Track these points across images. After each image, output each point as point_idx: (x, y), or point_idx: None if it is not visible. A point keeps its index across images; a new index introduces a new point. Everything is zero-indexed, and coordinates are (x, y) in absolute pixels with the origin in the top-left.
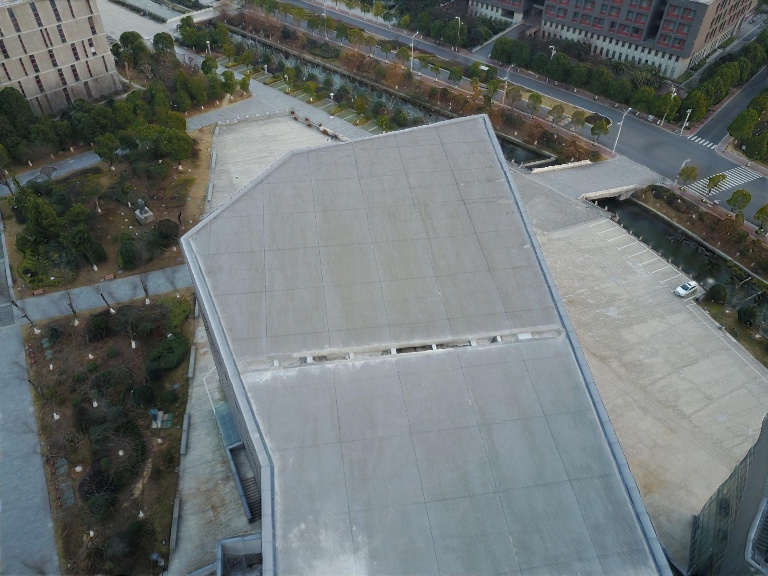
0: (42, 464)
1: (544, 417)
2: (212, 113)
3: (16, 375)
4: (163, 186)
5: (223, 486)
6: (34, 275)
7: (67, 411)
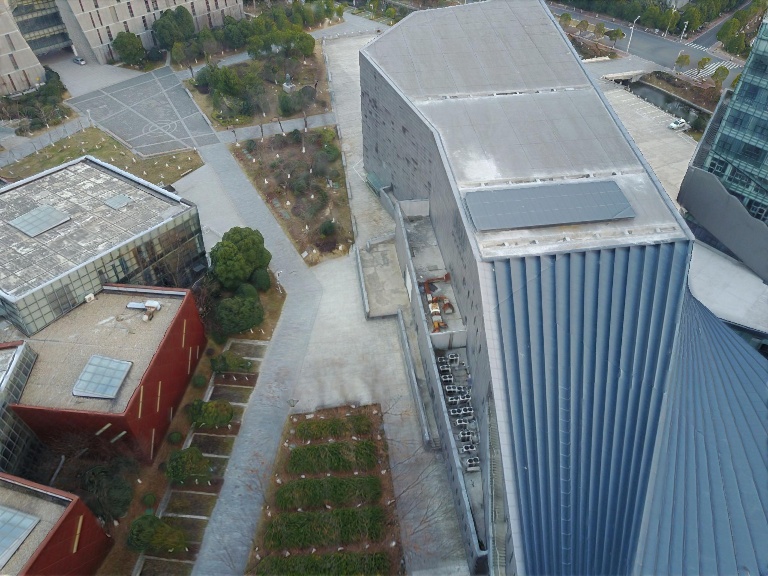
0: (264, 203)
1: (582, 117)
2: (318, 32)
3: (232, 166)
4: (296, 72)
5: (379, 212)
6: (225, 118)
7: (272, 180)
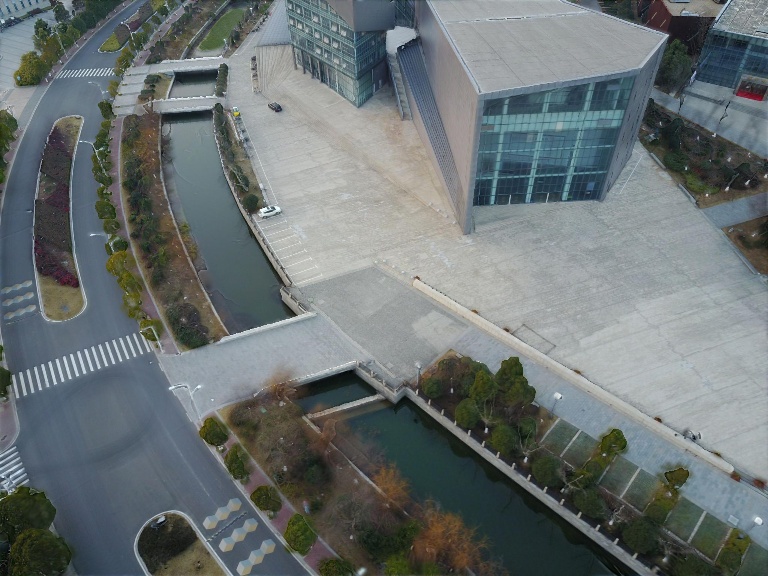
0: None
1: None
2: None
3: None
4: None
5: None
6: None
7: None
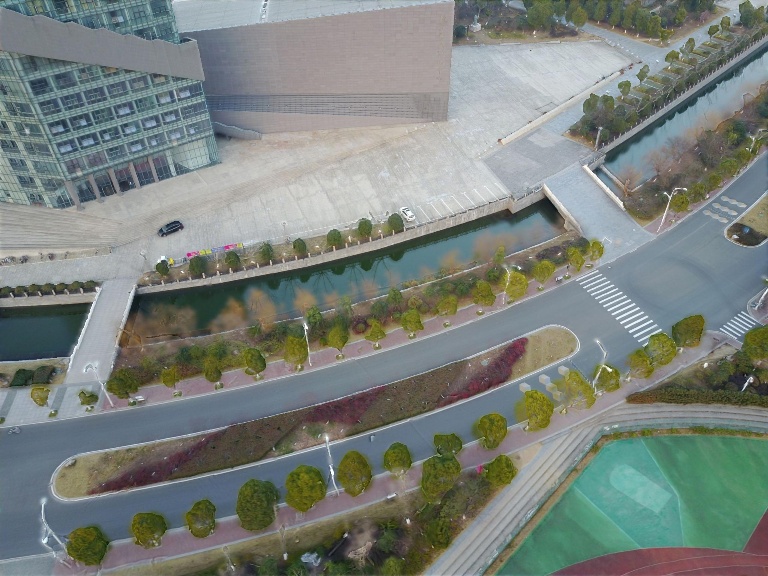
0: None
1: None
2: (622, 37)
3: None
4: (509, 29)
5: None
6: None
7: None
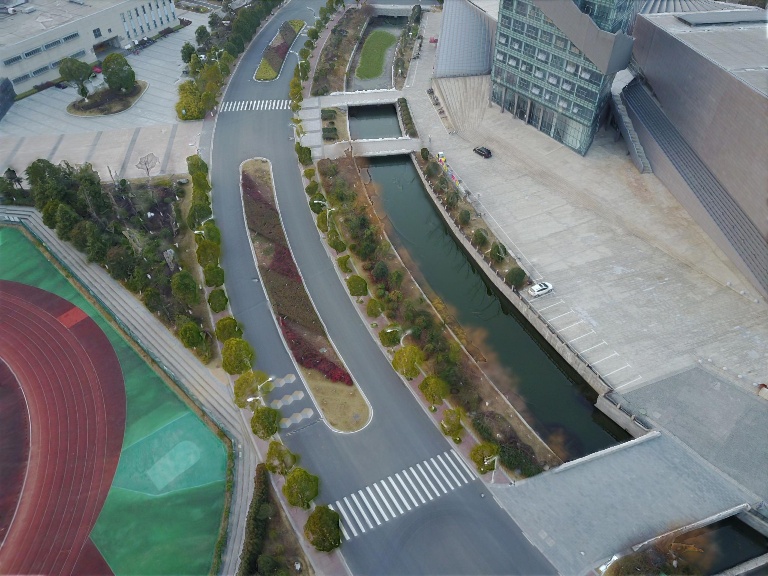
0: None
1: None
2: None
3: None
4: None
5: None
6: None
7: None
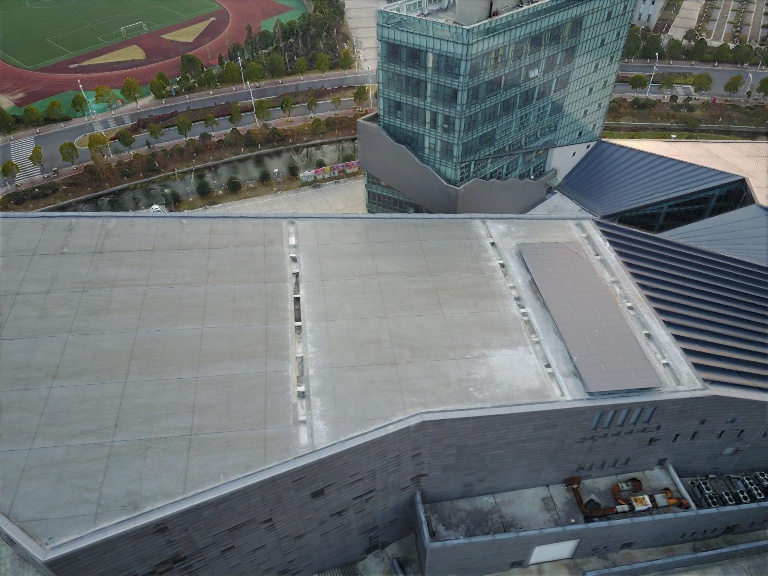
0: None
1: (371, 243)
2: None
3: None
4: None
5: None
6: None
7: None
